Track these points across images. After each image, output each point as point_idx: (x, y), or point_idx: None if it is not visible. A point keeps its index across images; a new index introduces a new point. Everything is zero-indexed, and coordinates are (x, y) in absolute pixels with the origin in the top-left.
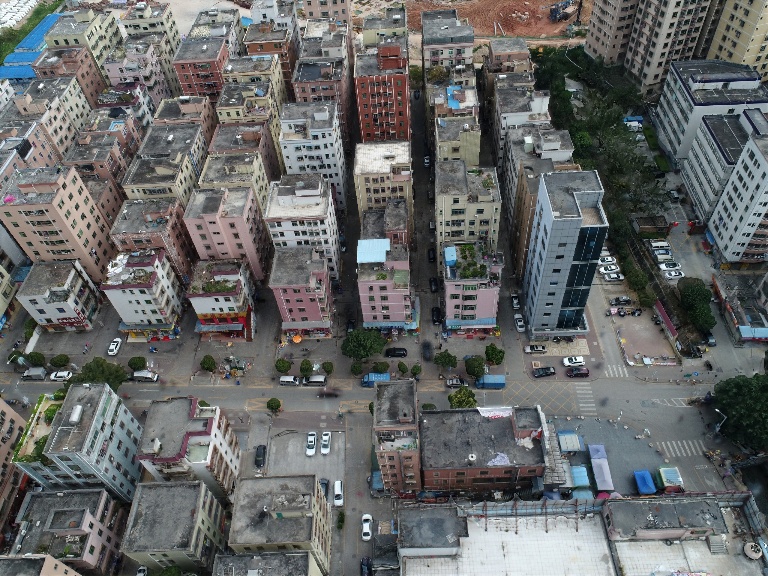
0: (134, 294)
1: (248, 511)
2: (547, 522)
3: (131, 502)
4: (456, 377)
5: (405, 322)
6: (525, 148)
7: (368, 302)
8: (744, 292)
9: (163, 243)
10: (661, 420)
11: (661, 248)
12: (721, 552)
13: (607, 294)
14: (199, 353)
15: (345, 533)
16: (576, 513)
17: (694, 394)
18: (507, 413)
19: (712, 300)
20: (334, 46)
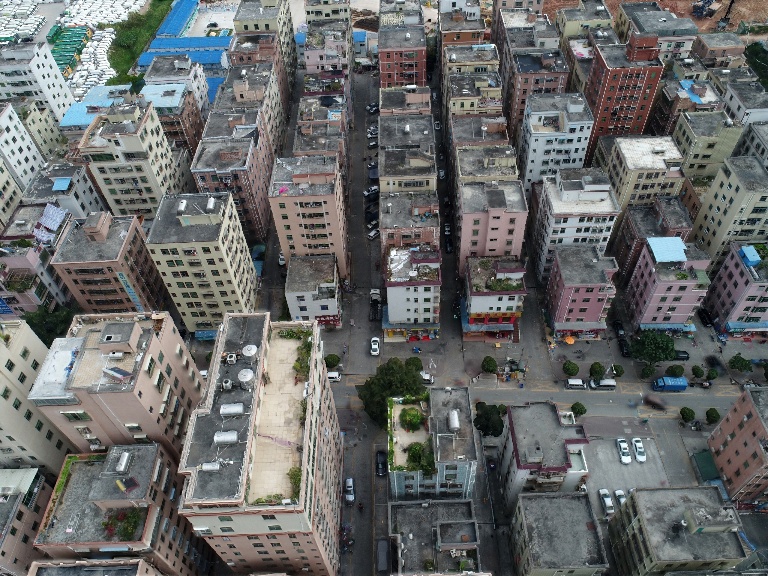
0: (417, 291)
1: (658, 525)
2: None
3: None
4: (749, 382)
5: (684, 324)
6: None
7: (657, 303)
8: None
9: (431, 238)
10: None
11: None
12: None
13: None
14: (467, 354)
15: None
16: None
17: None
18: None
19: None
20: (552, 37)
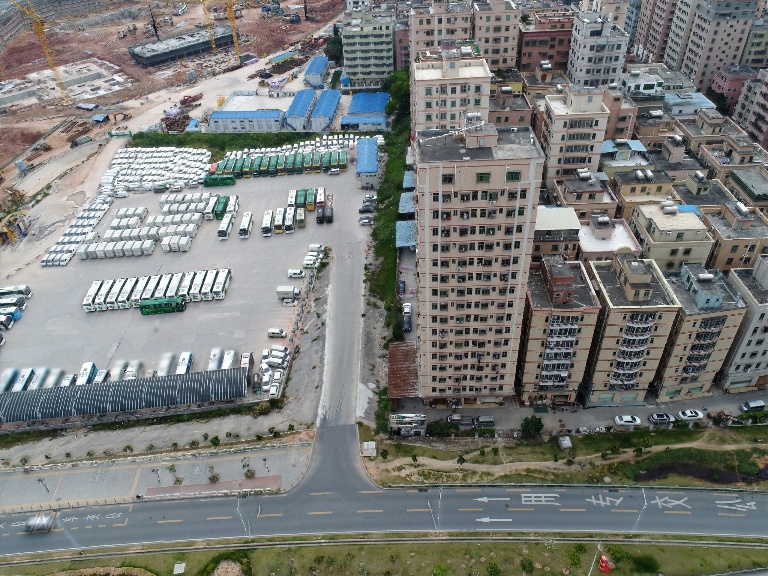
0: None
1: None
2: None
3: None
4: None
5: None
6: None
7: None
8: None
9: None
10: None
11: None
12: None
13: None
14: None
15: None
16: None
17: None
18: None
19: None
20: None
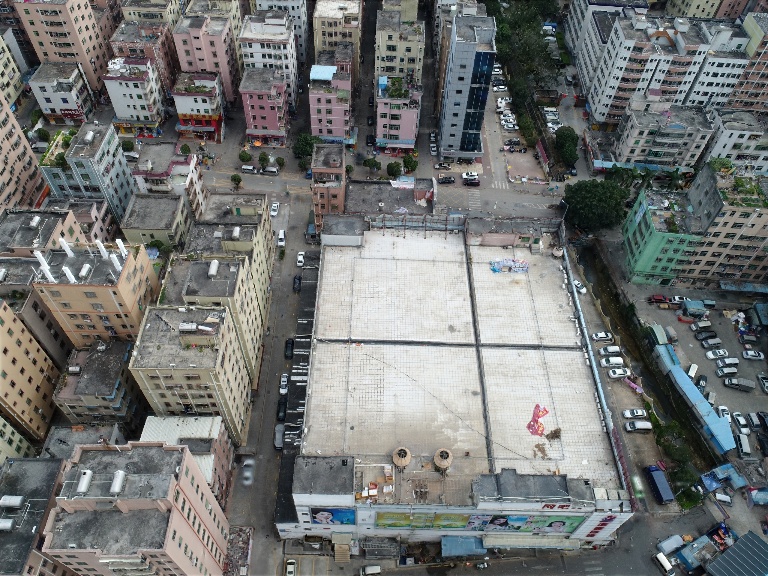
0: (129, 87)
1: (215, 211)
2: (426, 234)
3: (121, 230)
4: None
5: (344, 138)
6: (451, 14)
7: (316, 114)
8: (604, 142)
9: (154, 55)
10: (526, 215)
11: (551, 112)
12: (538, 254)
13: (504, 138)
14: None
15: (284, 262)
16: (446, 226)
17: (554, 202)
18: (411, 186)
19: (581, 148)
20: None
